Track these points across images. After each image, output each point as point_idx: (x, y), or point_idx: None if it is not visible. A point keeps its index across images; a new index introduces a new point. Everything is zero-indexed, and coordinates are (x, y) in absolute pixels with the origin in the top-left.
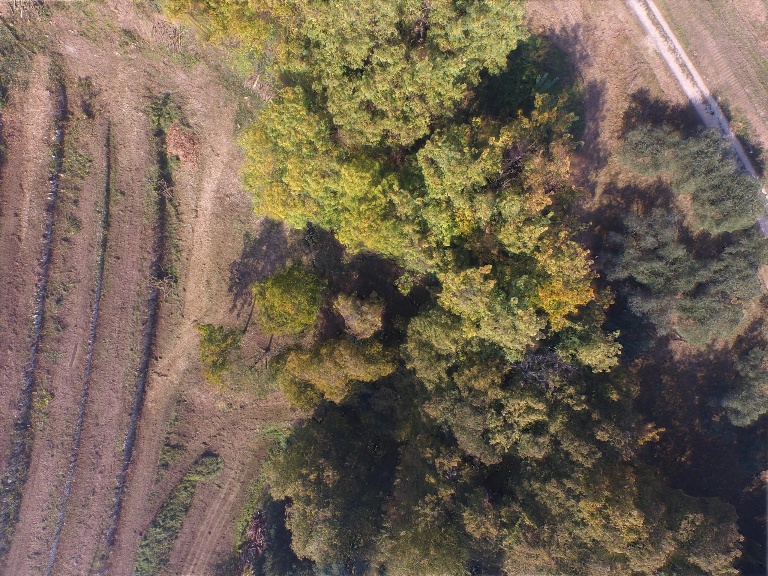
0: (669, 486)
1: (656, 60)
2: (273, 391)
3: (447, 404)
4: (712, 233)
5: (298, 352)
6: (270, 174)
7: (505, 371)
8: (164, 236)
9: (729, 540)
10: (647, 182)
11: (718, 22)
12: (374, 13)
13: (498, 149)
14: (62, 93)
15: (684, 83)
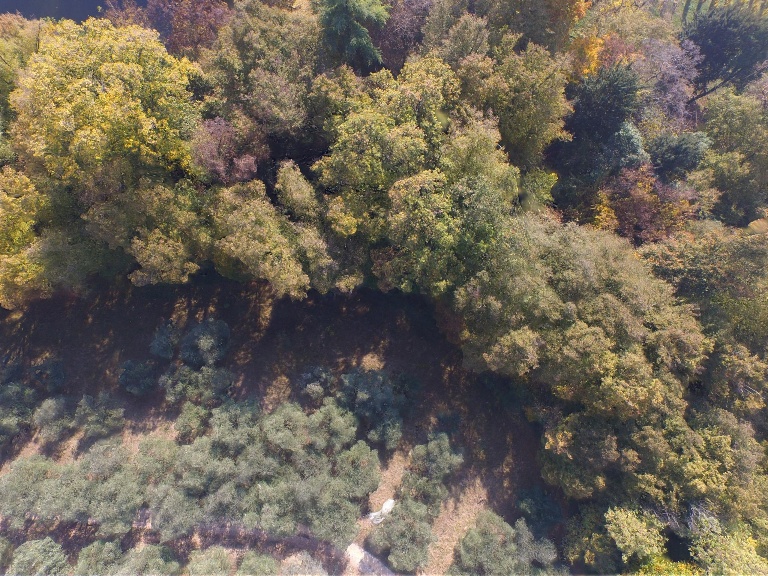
0: None
1: None
2: None
3: None
4: None
5: None
6: None
7: (717, 507)
8: None
9: (497, 354)
10: None
11: None
12: None
13: None
14: None
15: None
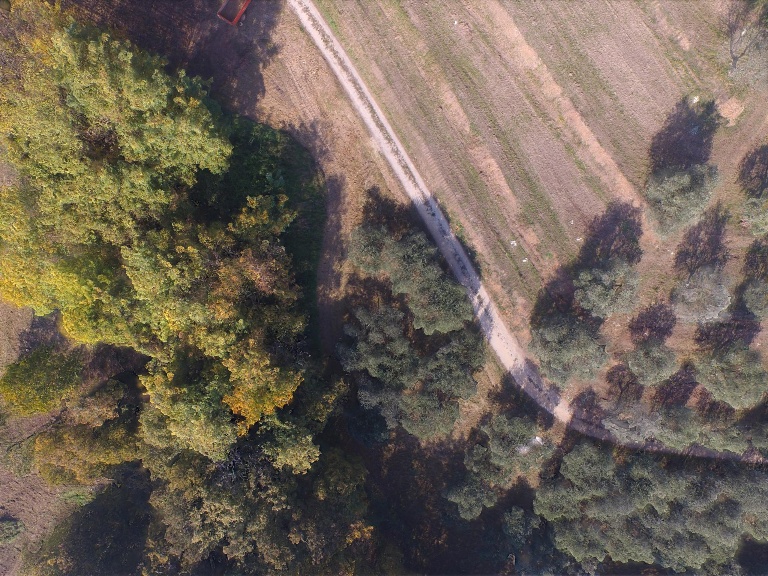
0: (429, 567)
1: (381, 161)
2: None
3: (166, 497)
4: (426, 333)
5: (45, 435)
6: (0, 265)
7: (209, 470)
8: None
9: None
10: (384, 275)
11: (430, 129)
12: (50, 128)
13: (195, 255)
14: None
15: (406, 184)
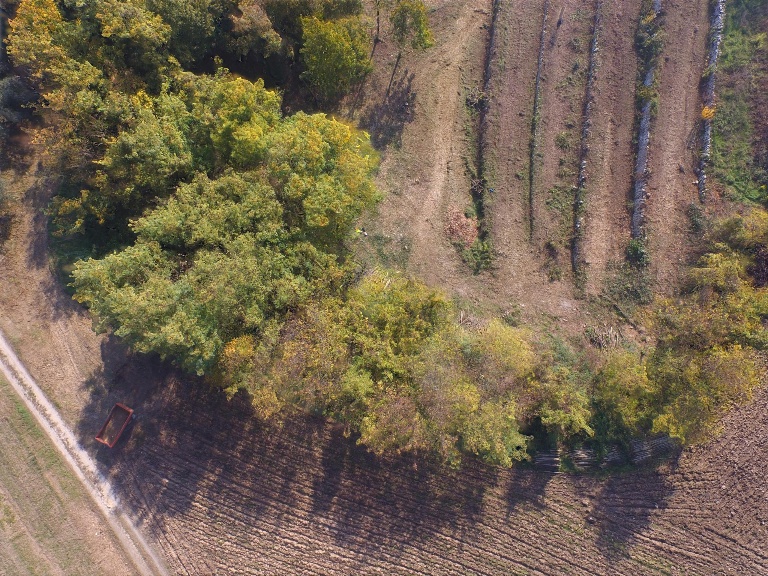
0: None
1: None
2: (375, 8)
3: None
4: None
5: (322, 1)
6: None
7: None
8: (479, 142)
9: None
10: None
11: None
12: (217, 264)
13: None
14: (575, 264)
15: None
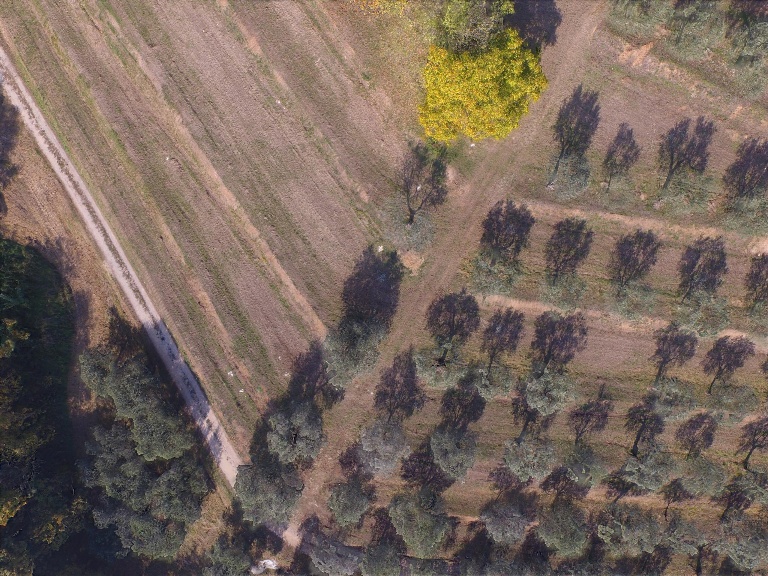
0: None
1: (113, 284)
2: None
3: None
4: None
5: None
6: None
7: None
8: None
9: None
10: None
11: (152, 258)
12: None
13: None
14: None
15: (137, 308)
